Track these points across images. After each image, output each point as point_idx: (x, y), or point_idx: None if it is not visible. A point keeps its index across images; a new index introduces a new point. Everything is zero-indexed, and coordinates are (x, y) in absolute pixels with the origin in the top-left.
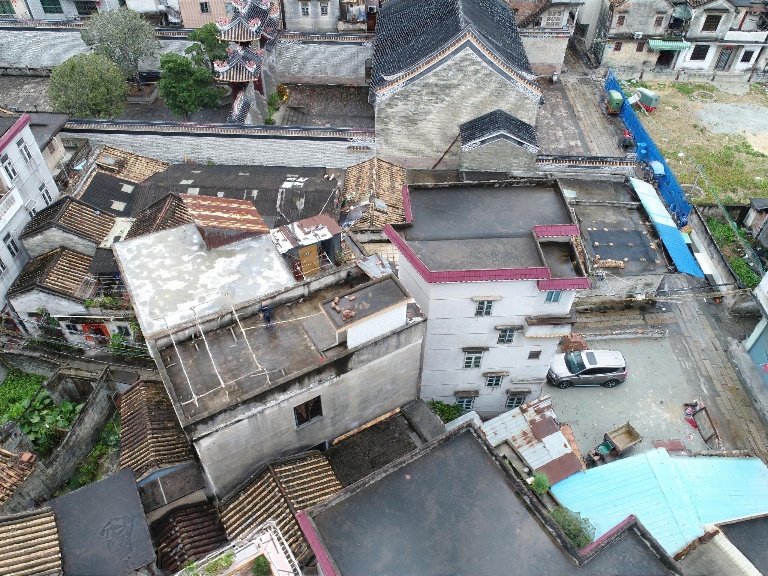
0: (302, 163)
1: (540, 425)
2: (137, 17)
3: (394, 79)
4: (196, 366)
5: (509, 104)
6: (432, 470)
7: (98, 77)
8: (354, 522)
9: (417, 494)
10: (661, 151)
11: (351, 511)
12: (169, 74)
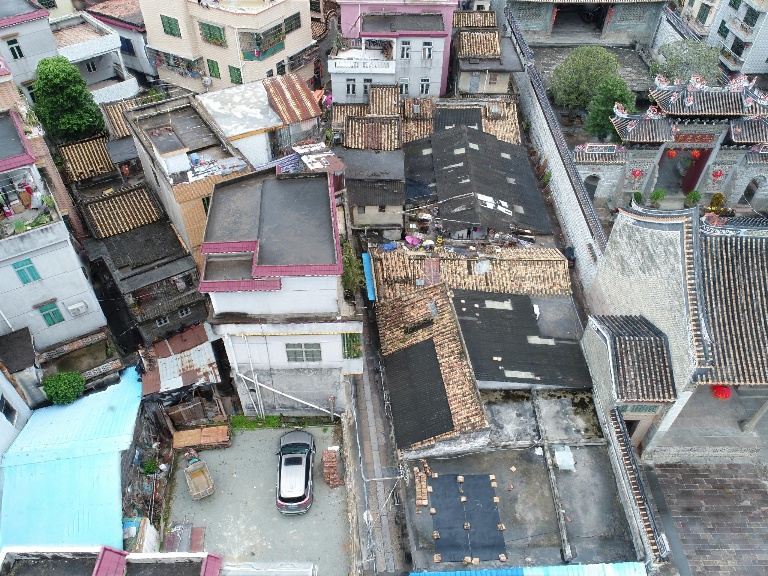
0: (572, 227)
1: (193, 374)
2: (704, 59)
3: (635, 210)
4: (176, 118)
5: (676, 341)
6: (12, 146)
7: (584, 67)
8: (1, 126)
9: (2, 142)
10: None
11: (7, 125)
12: (598, 92)
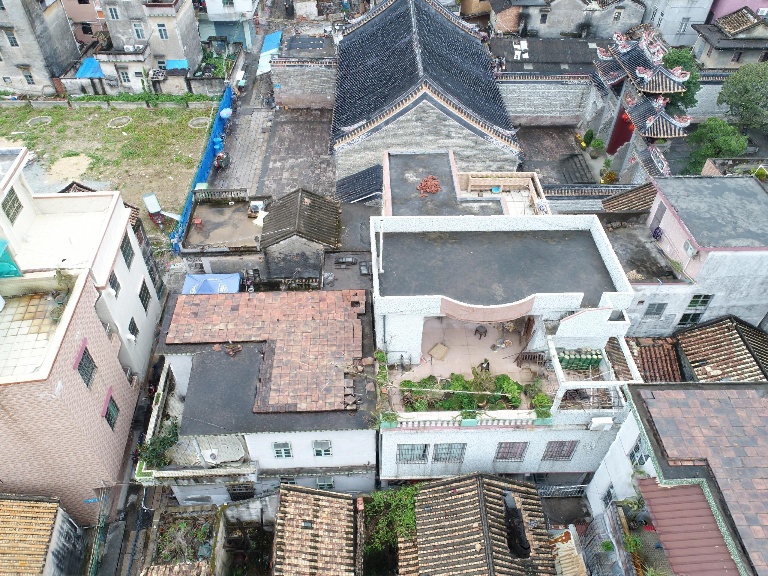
0: None
1: None
2: None
3: (467, 26)
4: None
5: None
6: None
7: None
8: None
9: None
10: (190, 159)
11: None
12: None
